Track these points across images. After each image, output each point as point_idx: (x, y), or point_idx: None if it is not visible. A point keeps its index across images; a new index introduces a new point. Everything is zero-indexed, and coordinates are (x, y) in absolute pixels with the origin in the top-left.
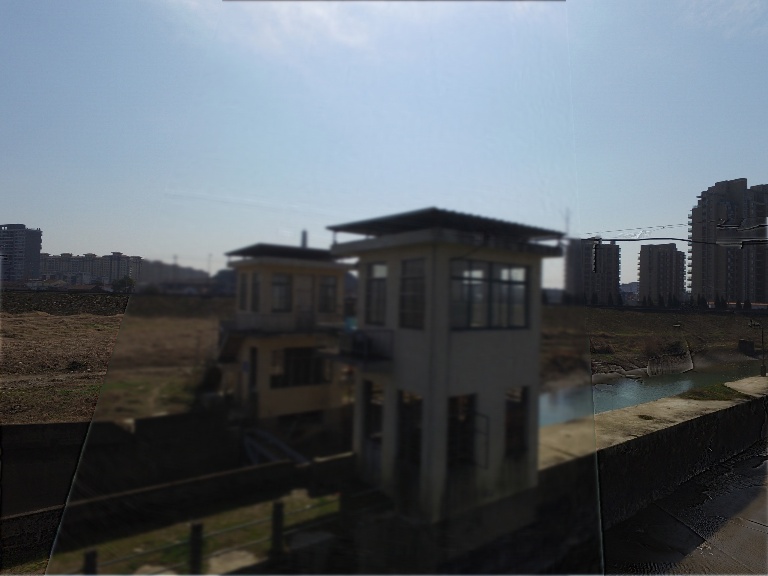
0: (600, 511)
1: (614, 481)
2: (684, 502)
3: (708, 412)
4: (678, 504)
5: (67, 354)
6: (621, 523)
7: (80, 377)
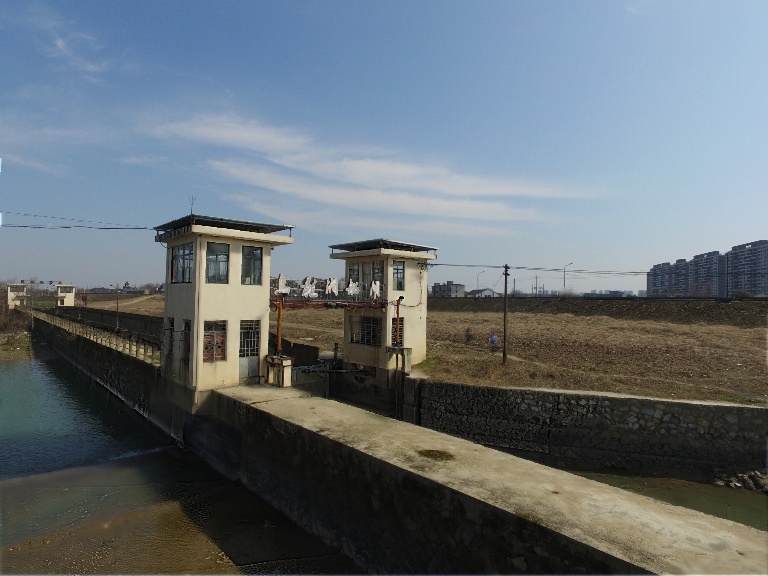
0: None
1: None
2: (337, 575)
3: (573, 533)
4: None
5: None
6: None
7: None
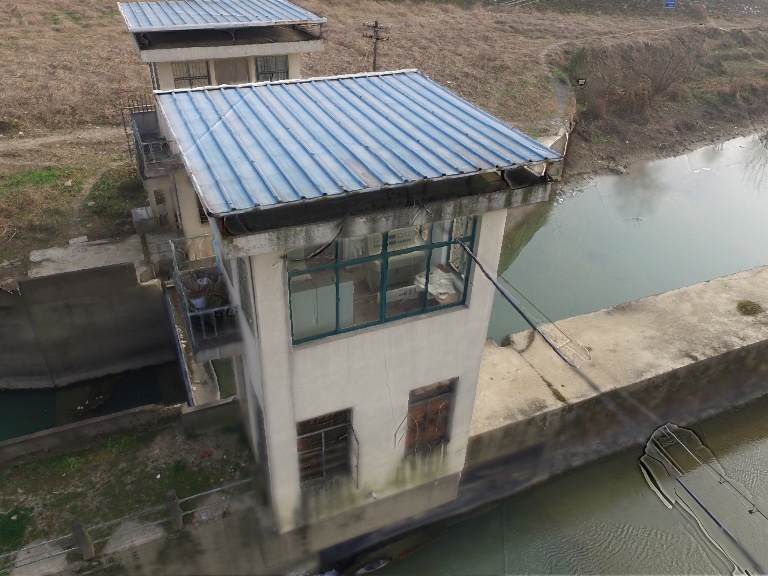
0: (596, 446)
1: (631, 416)
2: (743, 431)
3: None
4: (732, 433)
5: (0, 98)
6: (631, 451)
7: (5, 153)
